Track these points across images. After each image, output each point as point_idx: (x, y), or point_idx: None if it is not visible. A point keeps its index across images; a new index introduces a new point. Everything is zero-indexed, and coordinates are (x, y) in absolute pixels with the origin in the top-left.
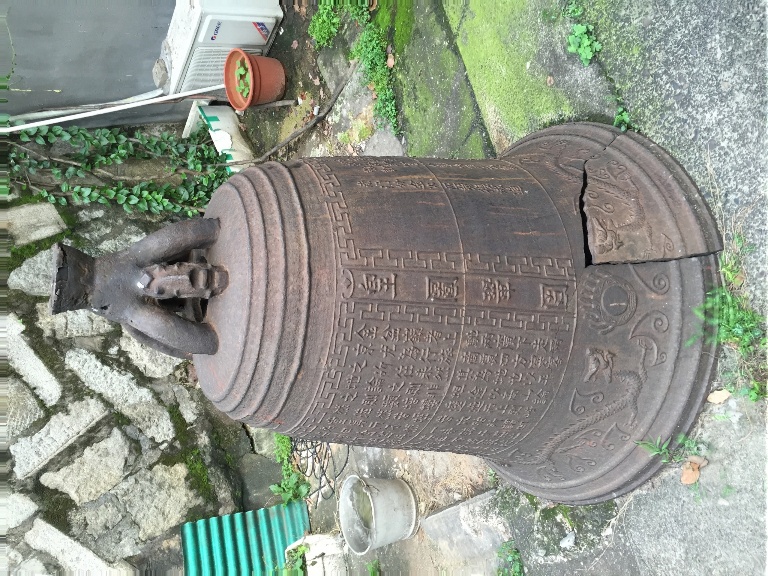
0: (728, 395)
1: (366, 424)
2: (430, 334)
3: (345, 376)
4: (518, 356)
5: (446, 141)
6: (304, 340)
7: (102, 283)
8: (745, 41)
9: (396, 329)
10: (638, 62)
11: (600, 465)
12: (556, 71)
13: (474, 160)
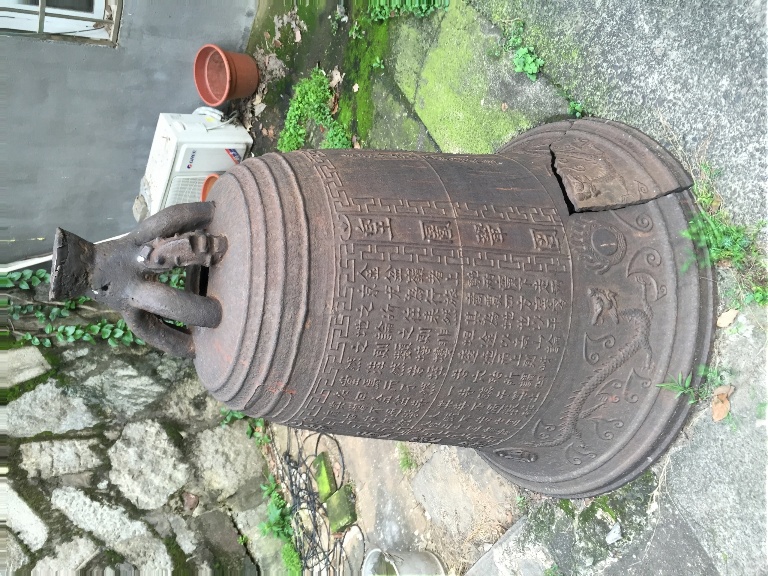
0: (736, 313)
1: (381, 384)
2: (432, 274)
3: (353, 321)
4: (522, 298)
5: None
6: (308, 283)
7: (102, 261)
8: (666, 11)
9: (398, 269)
10: (579, 62)
11: (628, 424)
12: (508, 97)
13: None
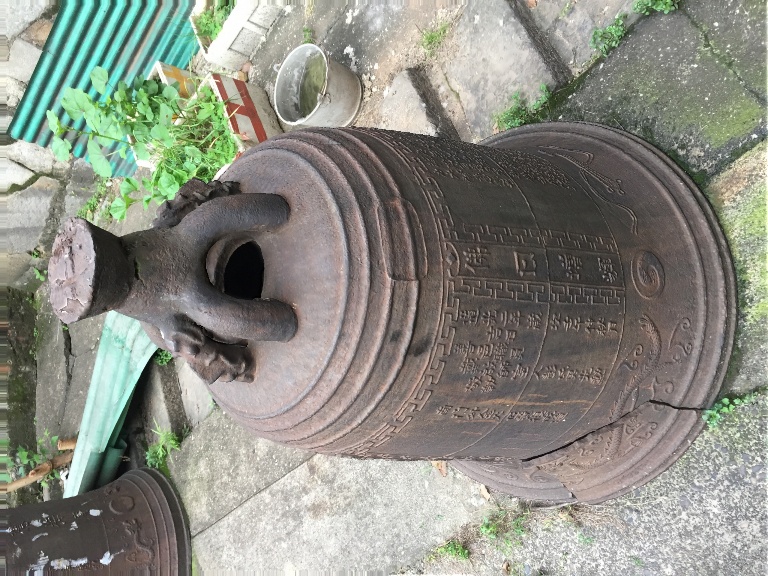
0: (487, 498)
1: None
2: None
3: None
4: None
5: (760, 36)
6: None
7: None
8: None
9: None
10: None
11: None
12: None
13: (600, 338)
